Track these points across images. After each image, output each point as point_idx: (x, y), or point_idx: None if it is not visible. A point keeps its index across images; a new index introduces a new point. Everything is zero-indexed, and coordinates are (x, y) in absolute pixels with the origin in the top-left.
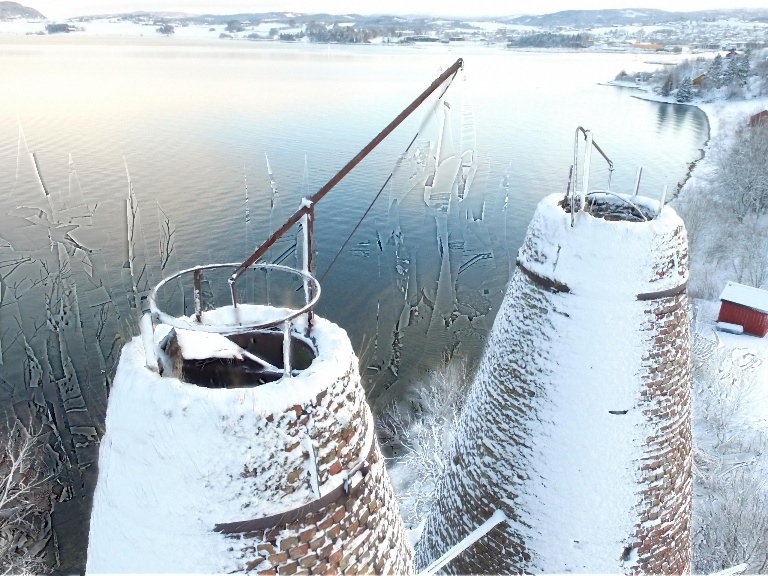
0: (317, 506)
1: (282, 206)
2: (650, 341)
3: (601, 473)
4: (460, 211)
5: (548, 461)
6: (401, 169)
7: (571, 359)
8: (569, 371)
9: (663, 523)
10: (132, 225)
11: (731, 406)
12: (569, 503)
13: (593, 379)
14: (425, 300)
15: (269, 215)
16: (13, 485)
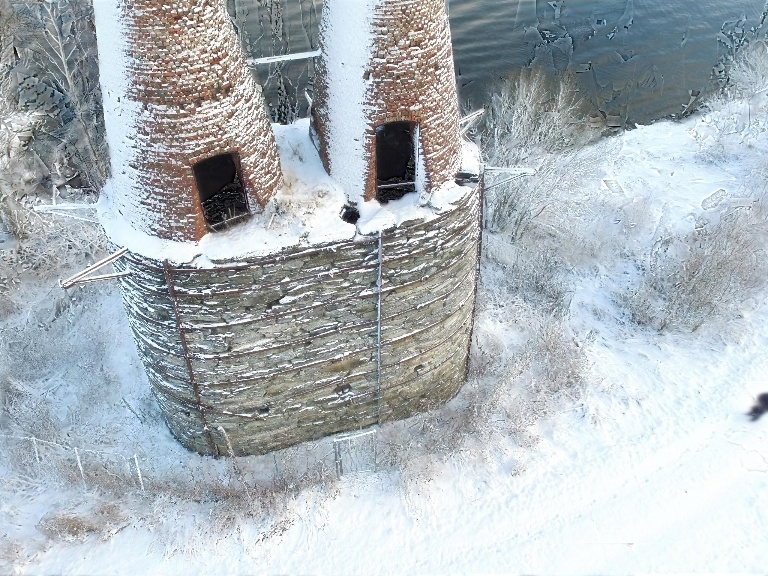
0: None
1: None
2: None
3: (351, 22)
4: None
5: (333, 15)
6: None
7: None
8: None
9: (389, 64)
10: None
11: None
12: (339, 39)
13: None
14: None
15: None
16: None
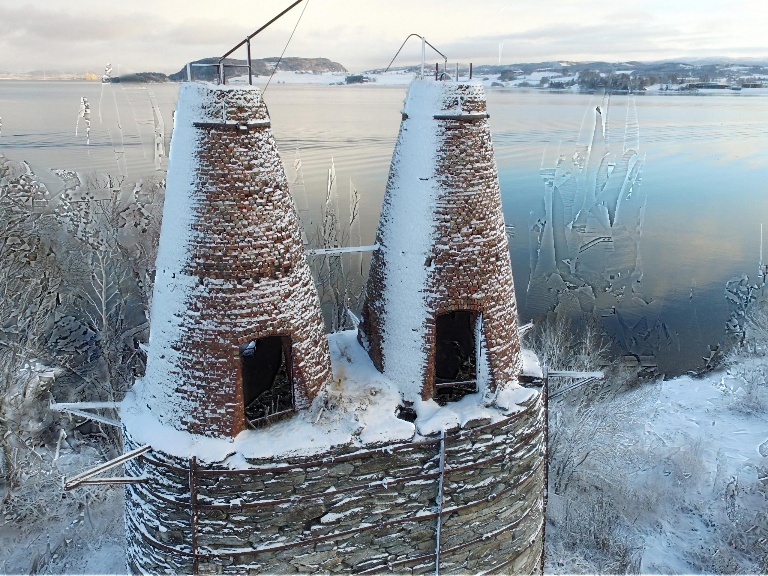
0: (225, 126)
1: None
2: (441, 142)
3: (414, 212)
4: (596, 203)
5: (395, 209)
6: (560, 170)
7: (405, 151)
8: None
9: (452, 250)
10: (329, 189)
11: None
12: (400, 229)
13: (412, 160)
14: None
15: None
16: None
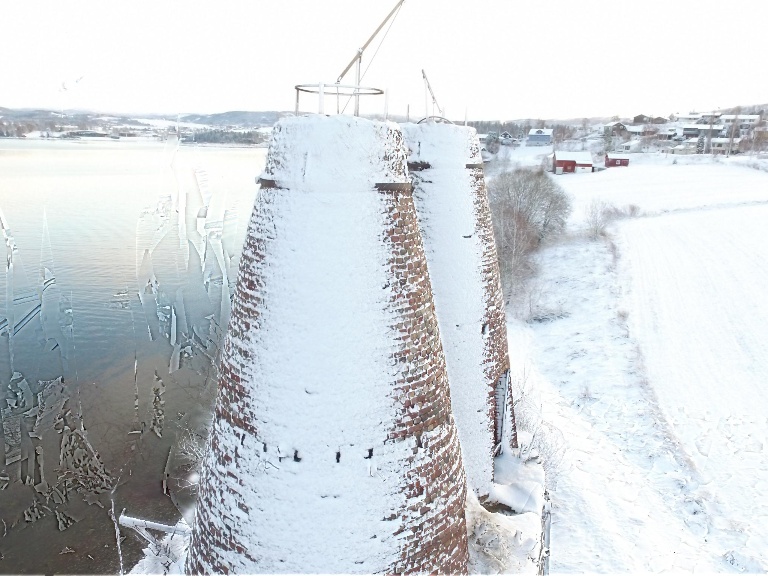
0: (408, 186)
1: (22, 263)
2: (475, 193)
3: (465, 276)
4: None
5: (434, 277)
6: (145, 223)
7: (438, 207)
8: (438, 215)
9: (497, 310)
10: None
11: None
12: (450, 300)
13: (452, 217)
14: (196, 338)
15: (5, 276)
16: None
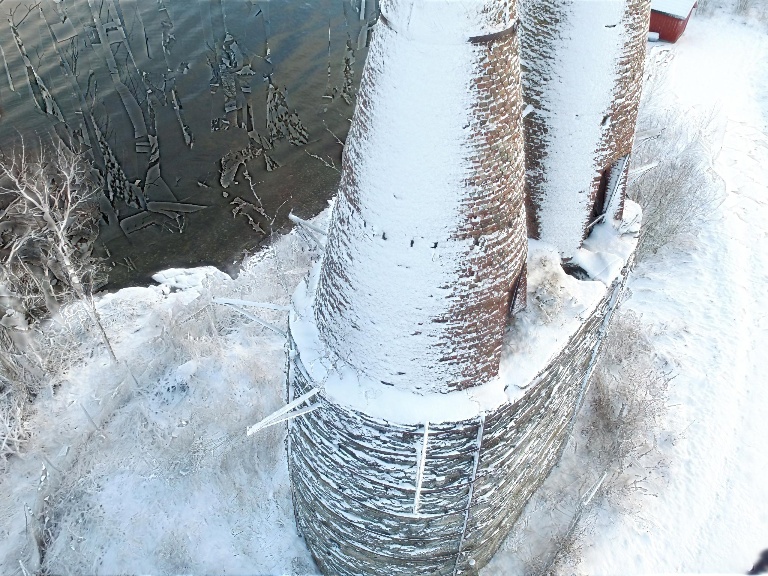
0: None
1: None
2: None
3: (596, 68)
4: None
5: (565, 65)
6: None
7: None
8: (584, 0)
9: (626, 101)
10: None
11: (644, 99)
12: (576, 90)
13: (598, 4)
14: None
15: None
16: (73, 195)
